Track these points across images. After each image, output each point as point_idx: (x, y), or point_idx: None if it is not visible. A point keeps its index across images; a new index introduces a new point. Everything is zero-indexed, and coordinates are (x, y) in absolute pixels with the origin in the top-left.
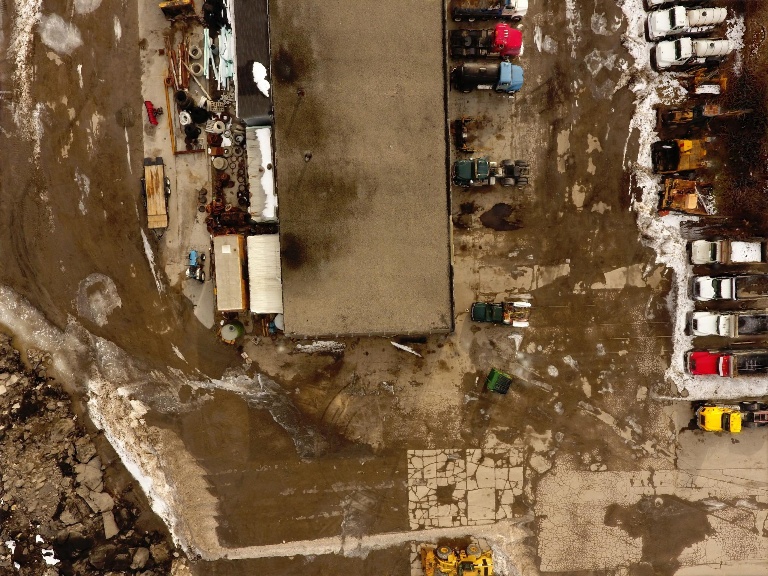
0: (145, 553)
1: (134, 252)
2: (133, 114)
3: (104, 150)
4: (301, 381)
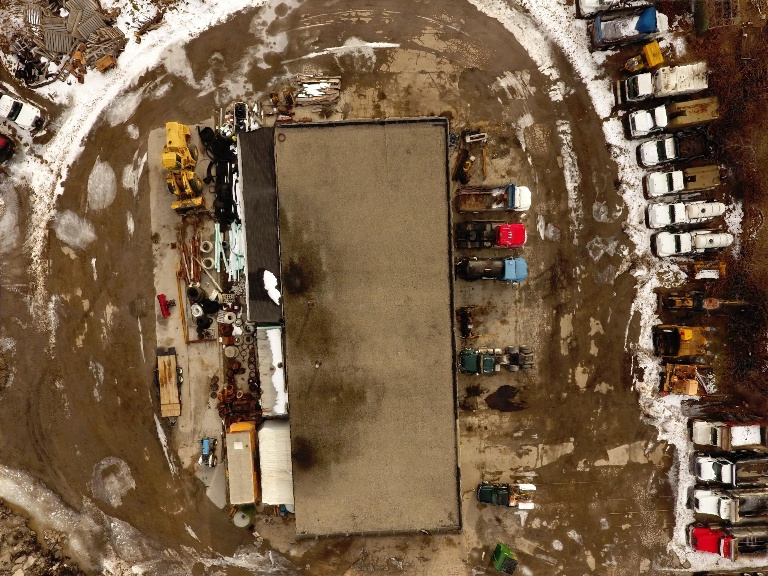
0: None
1: (147, 436)
2: (146, 305)
3: (118, 339)
4: (311, 557)
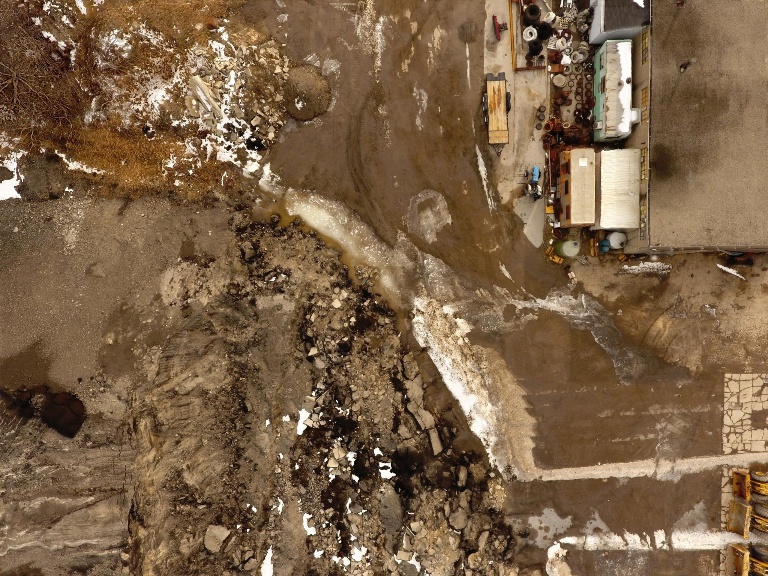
0: (465, 472)
1: (467, 169)
2: (475, 29)
3: (444, 65)
4: (624, 302)
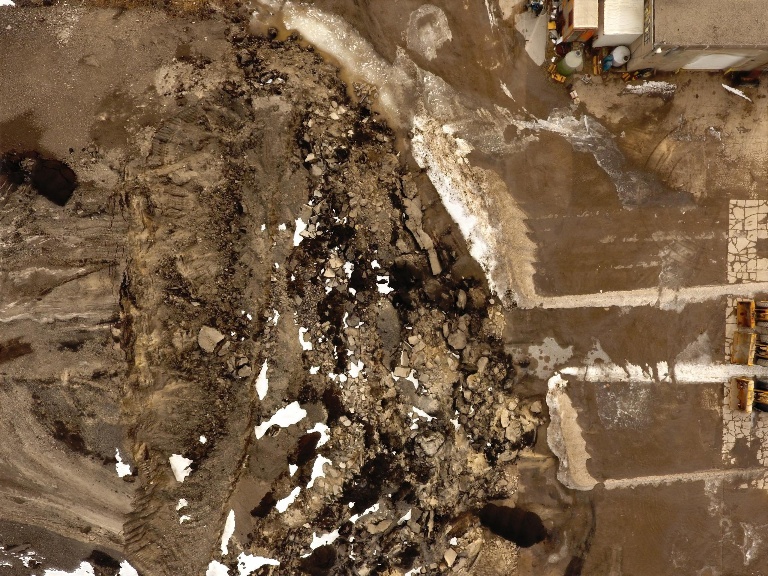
0: (464, 296)
1: None
2: None
3: None
4: (627, 124)
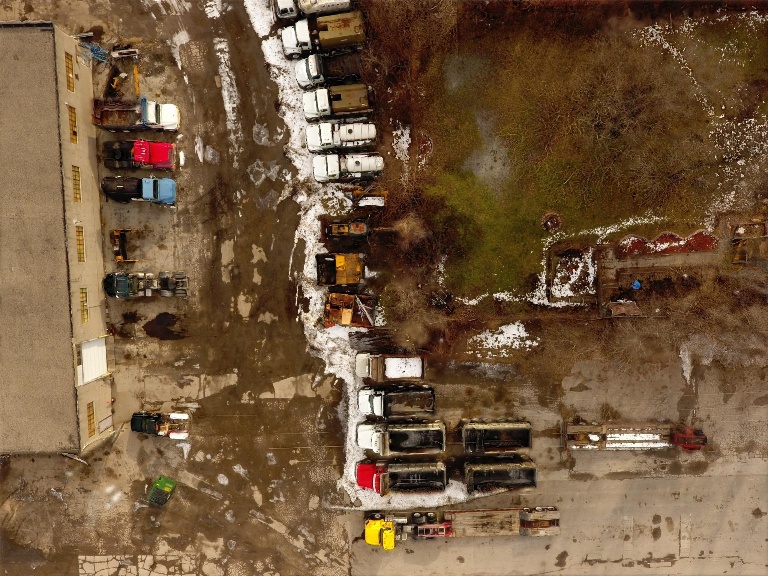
0: None
1: None
2: None
3: None
4: None
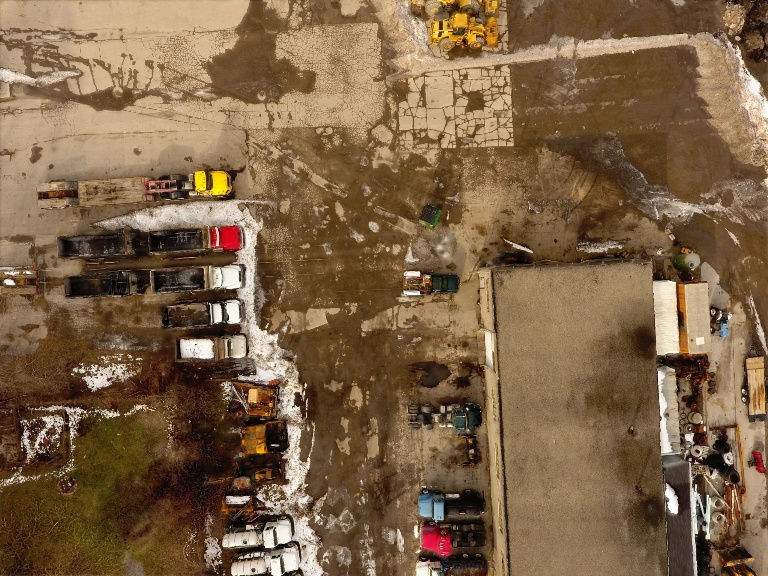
0: None
1: None
2: None
3: None
4: (617, 213)
